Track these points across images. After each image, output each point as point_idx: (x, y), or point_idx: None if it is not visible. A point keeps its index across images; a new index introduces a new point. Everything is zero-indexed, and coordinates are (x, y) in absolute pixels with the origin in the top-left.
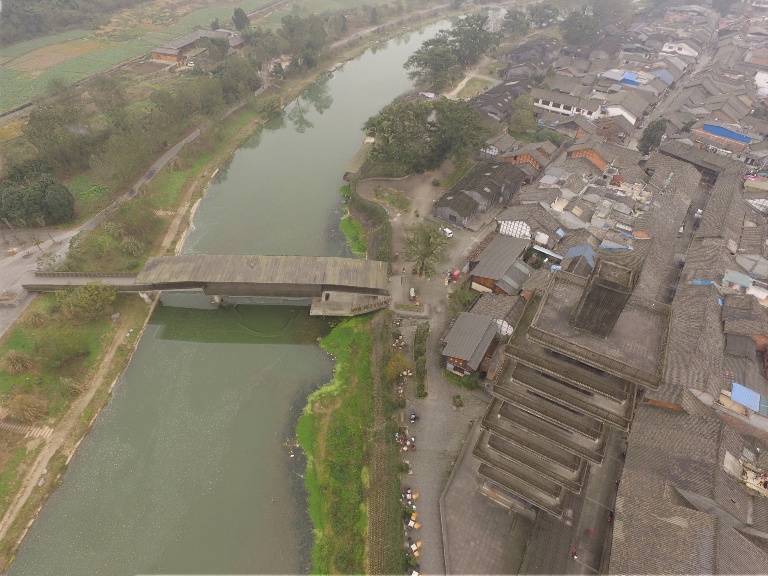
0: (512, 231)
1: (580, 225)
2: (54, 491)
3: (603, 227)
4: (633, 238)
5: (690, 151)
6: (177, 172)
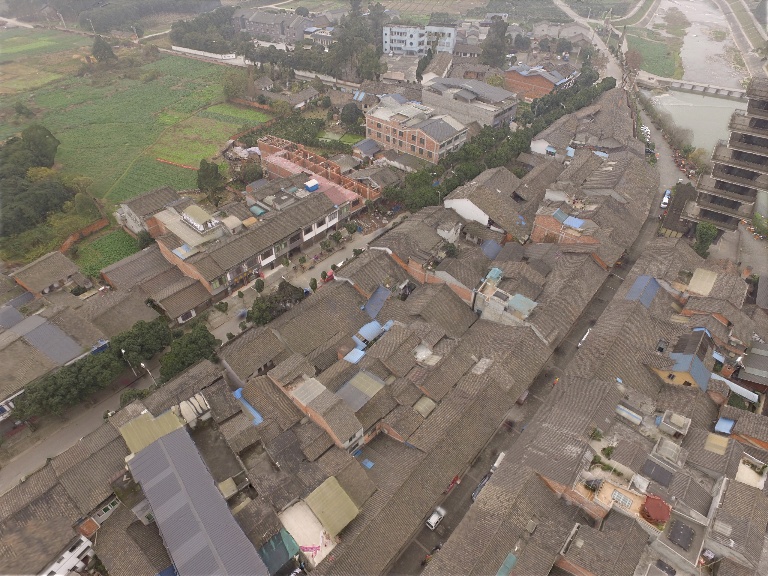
0: None
1: None
2: None
3: None
4: None
5: None
6: None
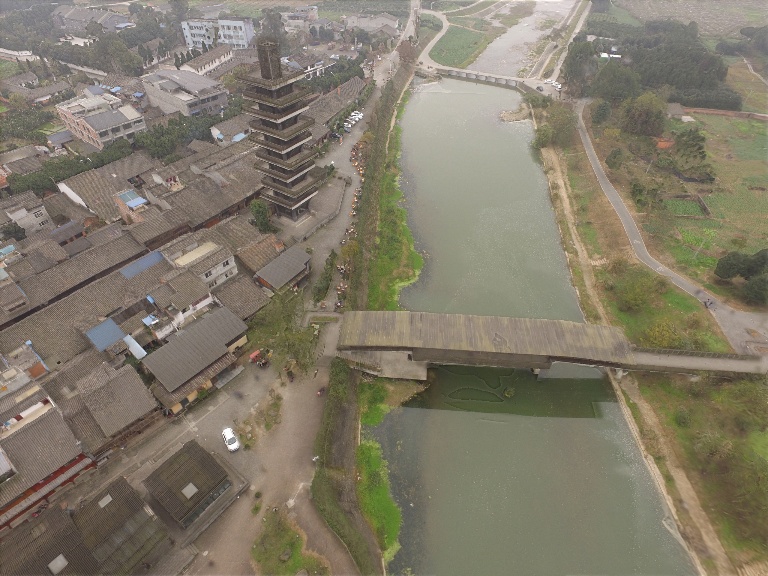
0: None
1: None
2: None
3: None
4: (4, 357)
5: None
6: None
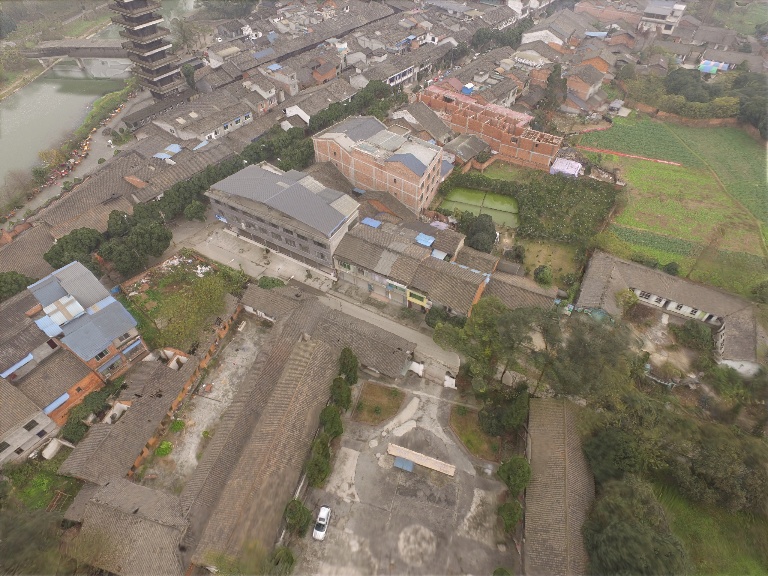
0: (247, 33)
1: (286, 30)
2: None
3: (295, 29)
4: None
5: (399, 1)
6: (86, 21)
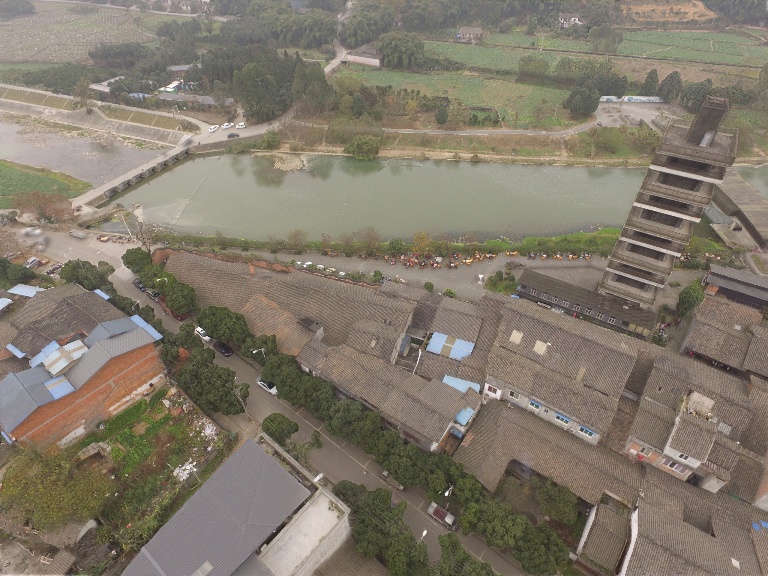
0: None
1: None
2: (540, 165)
3: None
4: None
5: None
6: None
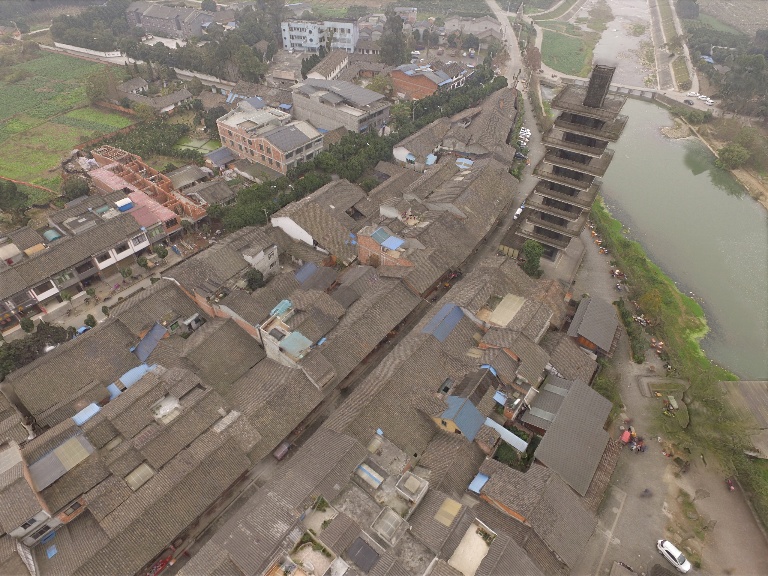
0: None
1: None
2: None
3: None
4: None
5: None
6: None
